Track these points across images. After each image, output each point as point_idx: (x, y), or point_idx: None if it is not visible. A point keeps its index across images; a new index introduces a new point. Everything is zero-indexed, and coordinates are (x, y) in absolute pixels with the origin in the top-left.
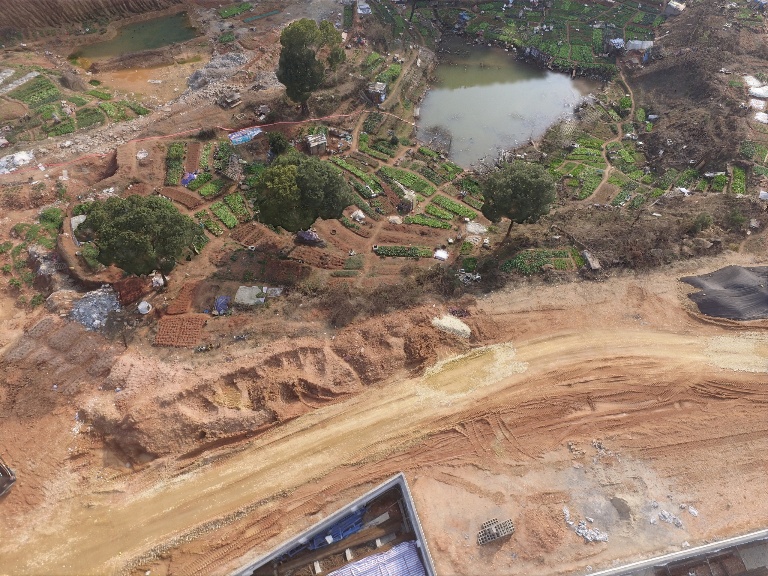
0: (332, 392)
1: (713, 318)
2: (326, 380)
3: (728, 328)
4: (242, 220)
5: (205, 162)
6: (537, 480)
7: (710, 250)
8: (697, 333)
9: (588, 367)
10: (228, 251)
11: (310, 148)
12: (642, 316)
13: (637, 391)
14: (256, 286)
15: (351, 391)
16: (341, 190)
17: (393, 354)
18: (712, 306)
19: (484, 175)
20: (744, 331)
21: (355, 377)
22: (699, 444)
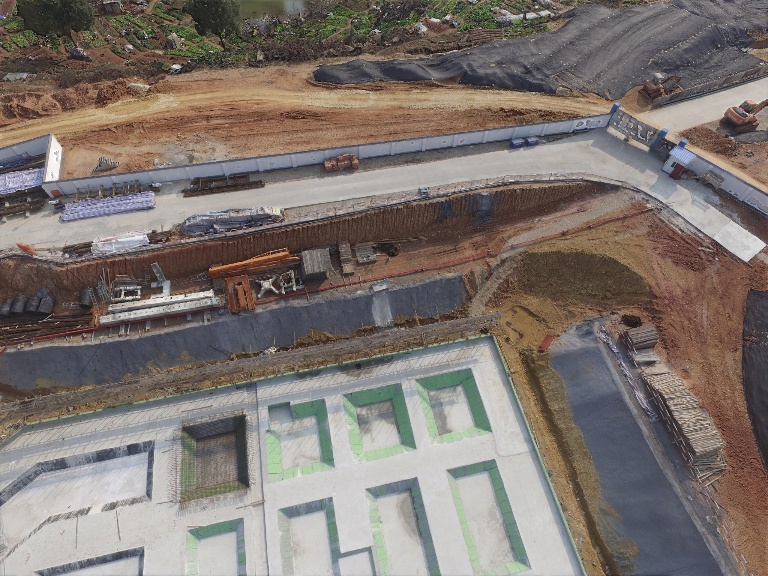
0: (39, 113)
1: (321, 83)
2: (36, 106)
3: (329, 88)
4: (32, 44)
5: (15, 10)
6: (147, 148)
7: (352, 53)
8: (306, 90)
9: (218, 104)
10: (12, 58)
11: (104, 6)
12: (274, 82)
13: (242, 114)
14: (21, 73)
15: (53, 114)
16: (77, 3)
17: (87, 95)
18: (322, 75)
19: (243, 29)
20: (339, 89)
21: (58, 107)
22: (262, 134)
